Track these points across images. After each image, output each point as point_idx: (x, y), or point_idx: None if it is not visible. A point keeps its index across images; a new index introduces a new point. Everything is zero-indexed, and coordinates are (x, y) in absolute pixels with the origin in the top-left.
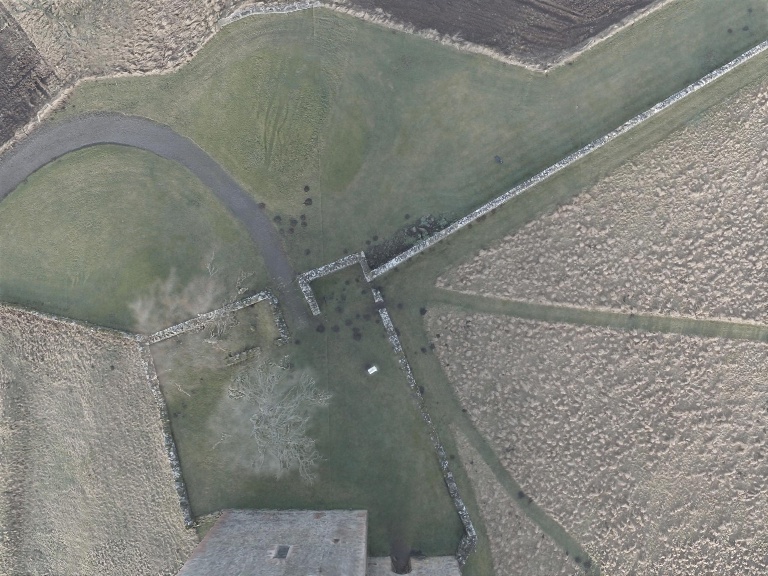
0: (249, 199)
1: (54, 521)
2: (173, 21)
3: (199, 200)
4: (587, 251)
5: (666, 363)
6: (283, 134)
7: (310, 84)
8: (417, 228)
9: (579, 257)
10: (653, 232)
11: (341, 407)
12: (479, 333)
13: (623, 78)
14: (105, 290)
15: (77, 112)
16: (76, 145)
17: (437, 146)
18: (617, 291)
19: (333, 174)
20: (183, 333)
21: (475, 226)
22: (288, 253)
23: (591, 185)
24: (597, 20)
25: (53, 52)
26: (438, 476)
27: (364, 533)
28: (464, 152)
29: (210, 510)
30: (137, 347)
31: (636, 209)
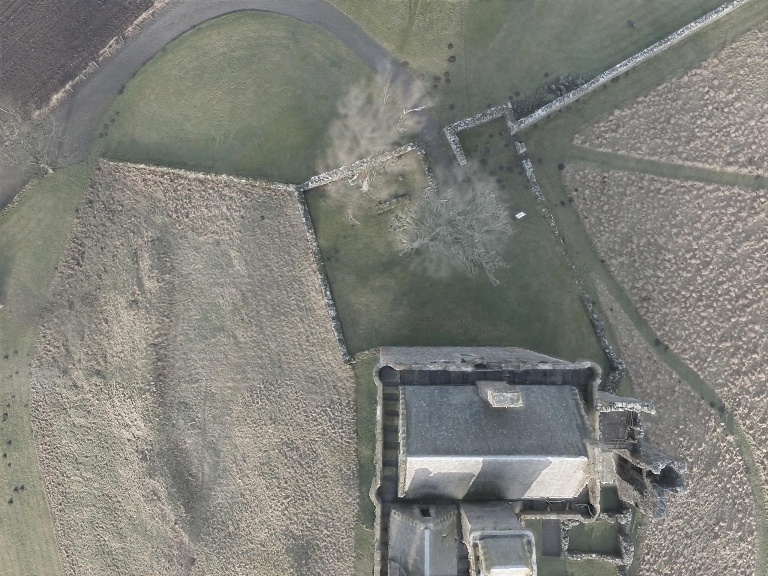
0: (392, 58)
1: (201, 371)
2: None
3: (341, 62)
4: (715, 114)
5: None
6: None
7: None
8: (556, 86)
9: (708, 119)
10: None
11: None
12: (615, 188)
13: None
14: (252, 146)
15: None
16: (216, 13)
17: (573, 10)
18: (744, 153)
19: (477, 32)
20: (334, 181)
21: (609, 87)
22: (433, 108)
23: (718, 51)
24: None
25: None
26: (584, 317)
27: None
28: (598, 16)
29: (365, 348)
30: (288, 197)
31: (761, 74)
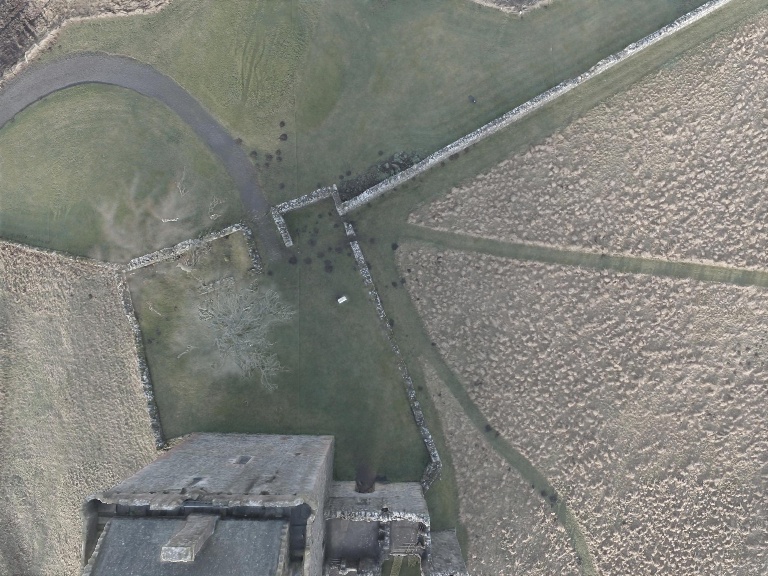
0: (226, 135)
1: (33, 447)
2: None
3: (178, 137)
4: (559, 191)
5: (636, 303)
6: (260, 70)
7: (287, 21)
8: (390, 164)
9: (551, 197)
10: (626, 174)
11: (311, 336)
12: (450, 269)
13: (598, 21)
14: (85, 222)
15: (63, 52)
16: (61, 84)
17: (411, 85)
18: (588, 231)
19: (308, 110)
20: (159, 262)
21: (448, 164)
22: (263, 187)
23: (564, 126)
24: None
25: None
26: (405, 405)
27: (327, 450)
28: (438, 91)
29: (181, 433)
30: (114, 276)
31: (609, 150)
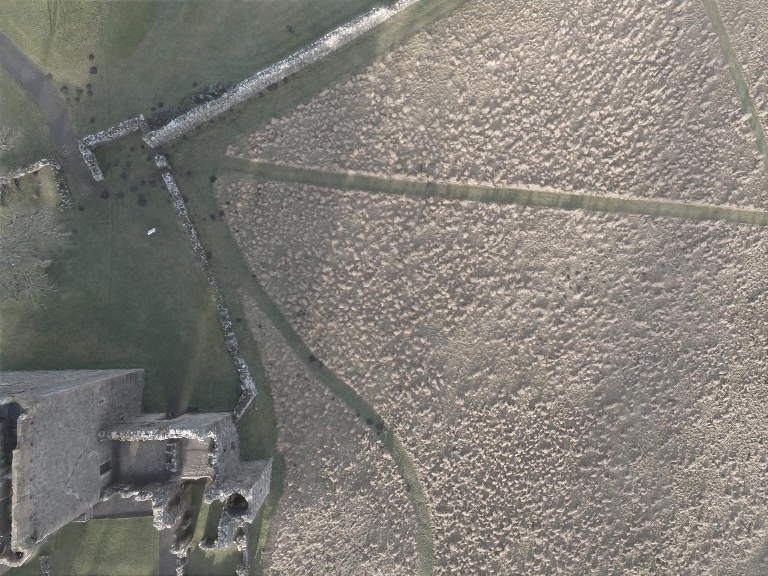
0: (37, 71)
1: None
2: None
3: None
4: (382, 120)
5: (464, 230)
6: (65, 2)
7: None
8: (205, 95)
9: (374, 126)
10: (450, 101)
11: (122, 270)
12: (270, 200)
13: None
14: None
15: None
16: None
17: (227, 16)
18: (413, 159)
19: (117, 41)
20: None
21: (267, 95)
22: (73, 122)
23: (386, 54)
24: None
25: None
26: (219, 336)
27: (116, 376)
28: (255, 22)
29: None
30: None
31: (432, 78)
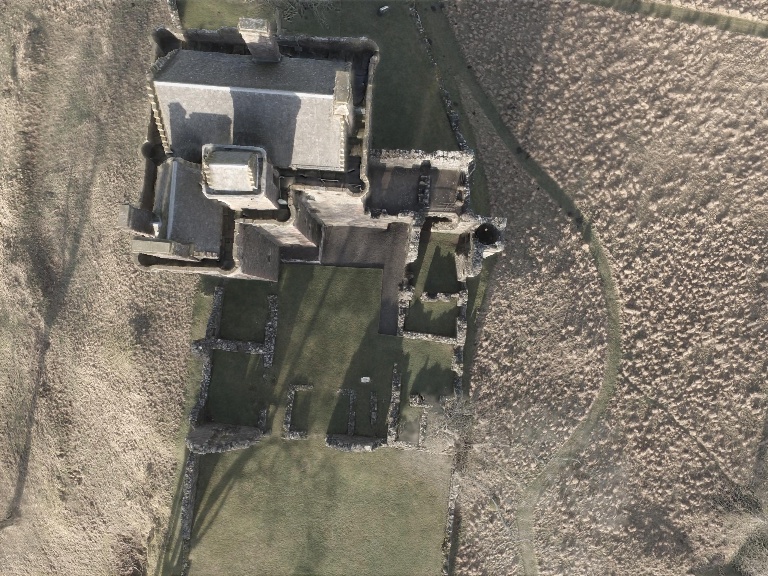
0: None
1: (67, 159)
2: None
3: None
4: None
5: (665, 48)
6: None
7: None
8: None
9: None
10: None
11: None
12: None
13: None
14: None
15: None
16: None
17: None
18: None
19: None
20: None
21: None
22: None
23: None
24: None
25: None
26: (441, 112)
27: None
28: None
29: None
30: None
31: None
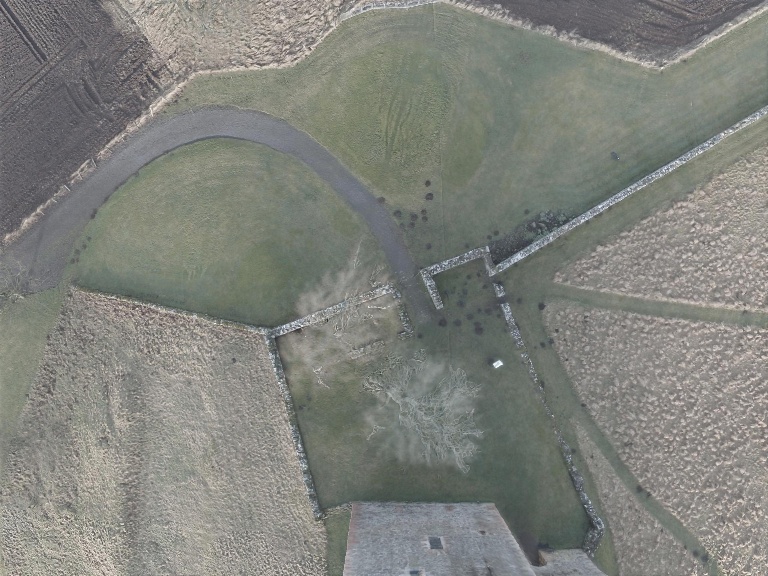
0: (368, 193)
1: (171, 513)
2: (291, 15)
3: (316, 194)
4: (701, 247)
5: None
6: (406, 129)
7: (433, 79)
8: (537, 223)
9: (694, 253)
10: (766, 229)
11: (465, 401)
12: (597, 328)
13: (737, 76)
14: (224, 283)
15: (190, 105)
16: (189, 138)
17: (555, 142)
18: (731, 287)
19: (455, 169)
20: (307, 326)
21: (592, 222)
22: (409, 247)
23: (705, 182)
24: (711, 18)
25: (166, 45)
26: (563, 470)
27: (506, 525)
28: (581, 148)
29: (337, 502)
30: (260, 340)
31: (749, 206)
